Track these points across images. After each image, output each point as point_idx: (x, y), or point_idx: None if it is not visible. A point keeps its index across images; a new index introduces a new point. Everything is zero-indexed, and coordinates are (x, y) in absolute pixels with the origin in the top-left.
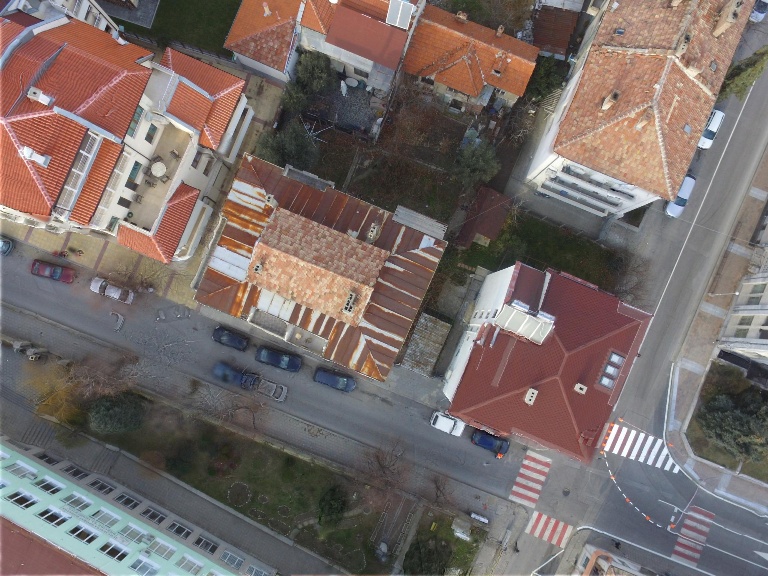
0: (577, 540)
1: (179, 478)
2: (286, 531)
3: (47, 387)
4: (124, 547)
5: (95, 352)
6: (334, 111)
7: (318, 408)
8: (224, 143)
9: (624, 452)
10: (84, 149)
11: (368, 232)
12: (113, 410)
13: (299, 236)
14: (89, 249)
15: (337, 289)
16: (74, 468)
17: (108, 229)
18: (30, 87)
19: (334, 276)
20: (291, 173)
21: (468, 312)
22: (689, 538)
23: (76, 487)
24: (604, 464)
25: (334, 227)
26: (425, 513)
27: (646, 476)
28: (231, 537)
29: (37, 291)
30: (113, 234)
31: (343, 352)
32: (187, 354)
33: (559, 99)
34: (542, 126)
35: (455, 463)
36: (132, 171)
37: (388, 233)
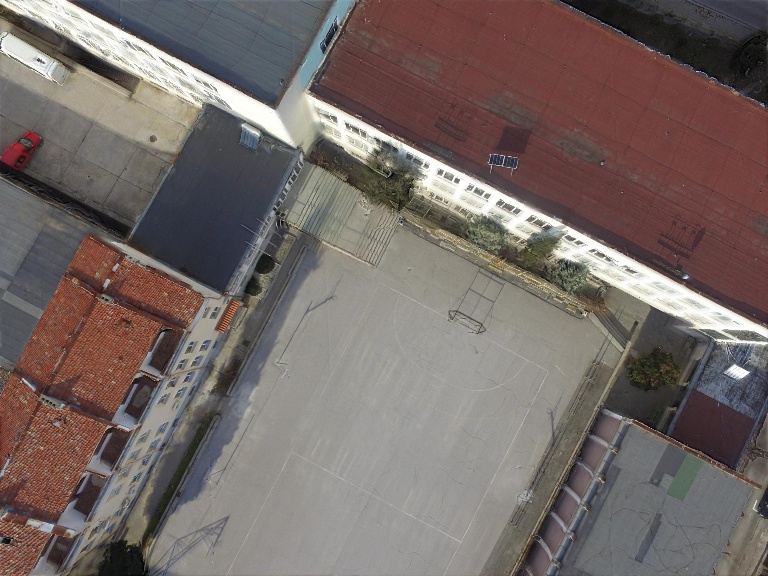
0: None
1: None
2: None
3: None
4: None
5: None
6: None
7: None
8: None
9: None
10: None
11: None
12: None
13: None
14: None
15: None
16: None
17: None
18: None
19: None
20: None
21: None
22: None
23: None
24: None
25: None
26: None
27: None
28: None
29: None
30: None
31: None
32: None
33: None
34: None
35: None
36: None
37: None
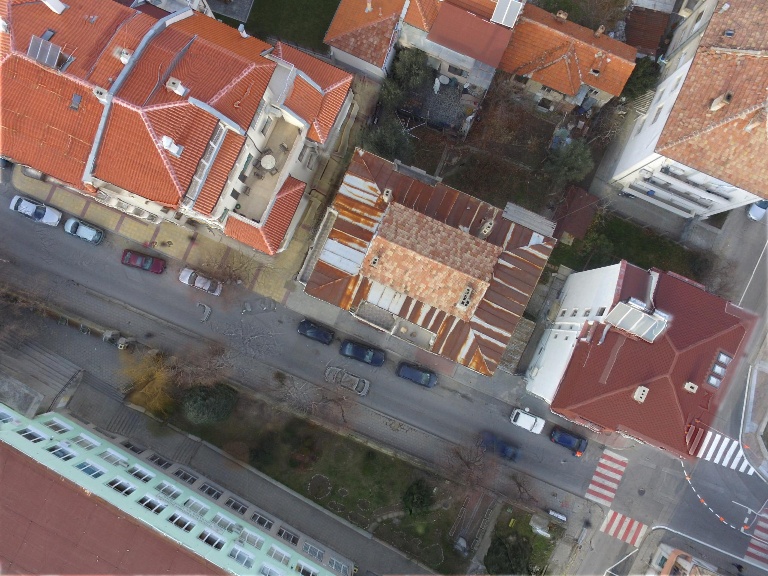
0: (652, 539)
1: (260, 469)
2: (365, 524)
3: (134, 376)
4: (220, 536)
5: (182, 342)
6: (426, 108)
7: (399, 403)
8: (332, 137)
9: (700, 453)
10: (212, 140)
11: (480, 228)
12: (209, 400)
13: (415, 230)
14: (178, 240)
15: (452, 284)
16: (157, 457)
17: (218, 220)
18: (169, 77)
19: (451, 271)
20: (400, 168)
21: (553, 310)
22: (762, 540)
23: (164, 476)
24: (680, 464)
25: (447, 222)
26: (504, 509)
27: (721, 477)
28: (310, 529)
29: (126, 281)
30: (222, 225)
31: (452, 346)
32: (272, 346)
33: (652, 101)
34: (630, 127)
35: (533, 460)
36: (245, 163)
37: (498, 229)
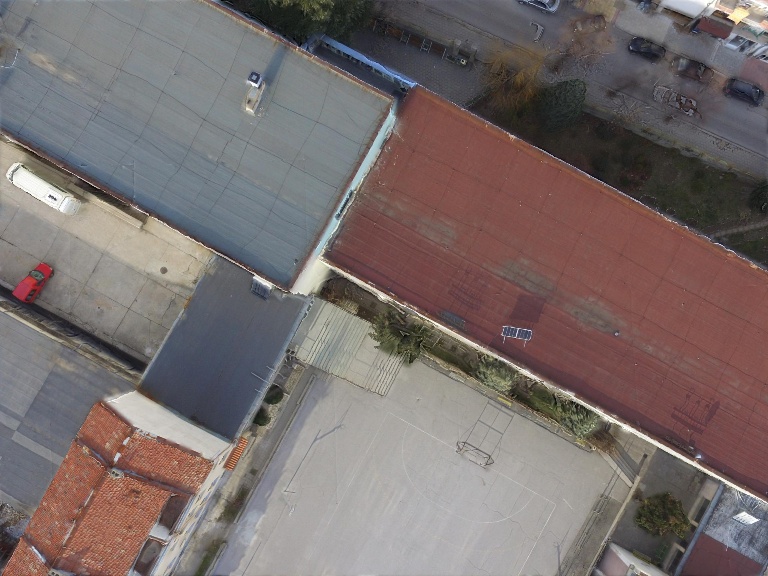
0: None
1: None
2: None
3: (472, 93)
4: None
5: (517, 60)
6: None
7: (725, 123)
8: None
9: None
10: None
11: None
12: None
13: None
14: None
15: None
16: None
17: None
18: None
19: None
20: None
21: None
22: None
23: None
24: None
25: None
26: None
27: None
28: None
29: None
30: None
31: None
32: (602, 66)
33: None
34: None
35: None
36: None
37: None
